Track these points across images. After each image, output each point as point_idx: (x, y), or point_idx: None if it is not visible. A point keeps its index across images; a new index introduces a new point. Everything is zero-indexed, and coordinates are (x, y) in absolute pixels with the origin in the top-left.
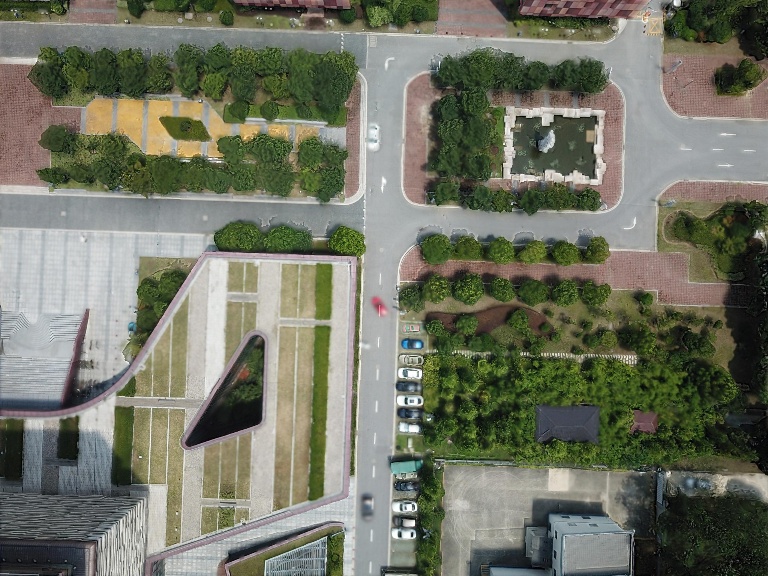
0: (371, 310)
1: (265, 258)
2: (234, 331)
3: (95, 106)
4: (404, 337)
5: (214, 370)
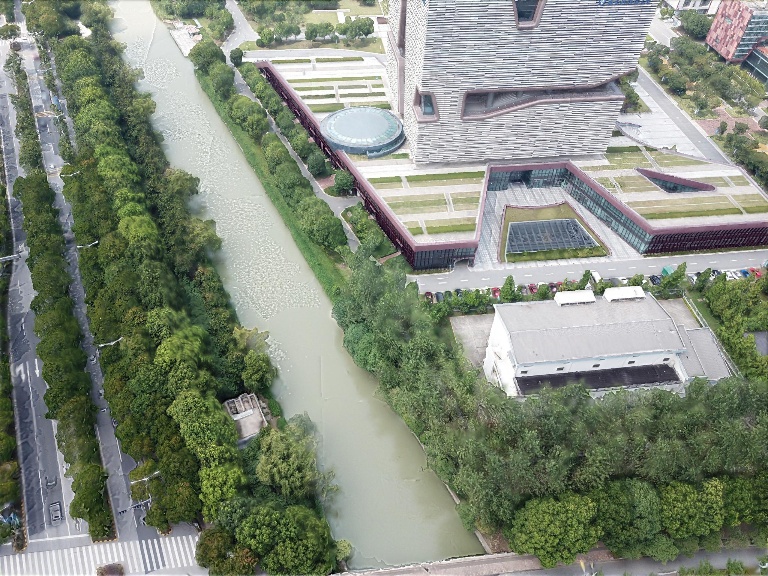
0: (749, 255)
1: (757, 187)
2: (708, 180)
3: (762, 145)
4: (747, 271)
5: (682, 175)
